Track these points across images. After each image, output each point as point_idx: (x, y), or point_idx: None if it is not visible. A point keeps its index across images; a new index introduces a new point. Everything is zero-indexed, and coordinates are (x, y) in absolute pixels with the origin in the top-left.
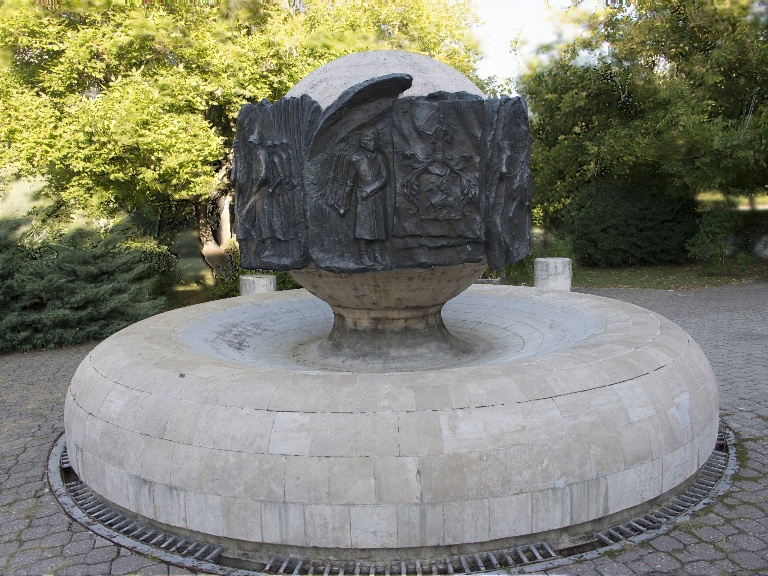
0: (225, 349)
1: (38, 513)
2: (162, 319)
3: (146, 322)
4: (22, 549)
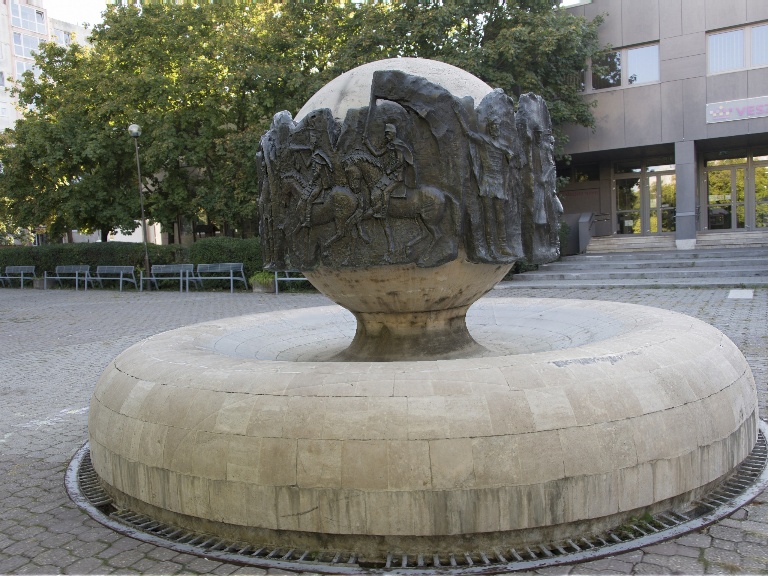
0: (579, 343)
1: (765, 410)
2: (628, 337)
3: (652, 335)
4: (765, 399)
